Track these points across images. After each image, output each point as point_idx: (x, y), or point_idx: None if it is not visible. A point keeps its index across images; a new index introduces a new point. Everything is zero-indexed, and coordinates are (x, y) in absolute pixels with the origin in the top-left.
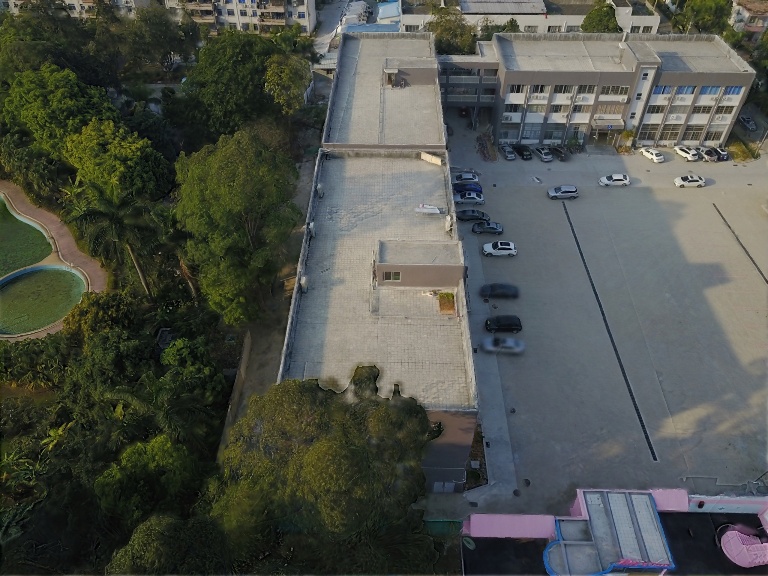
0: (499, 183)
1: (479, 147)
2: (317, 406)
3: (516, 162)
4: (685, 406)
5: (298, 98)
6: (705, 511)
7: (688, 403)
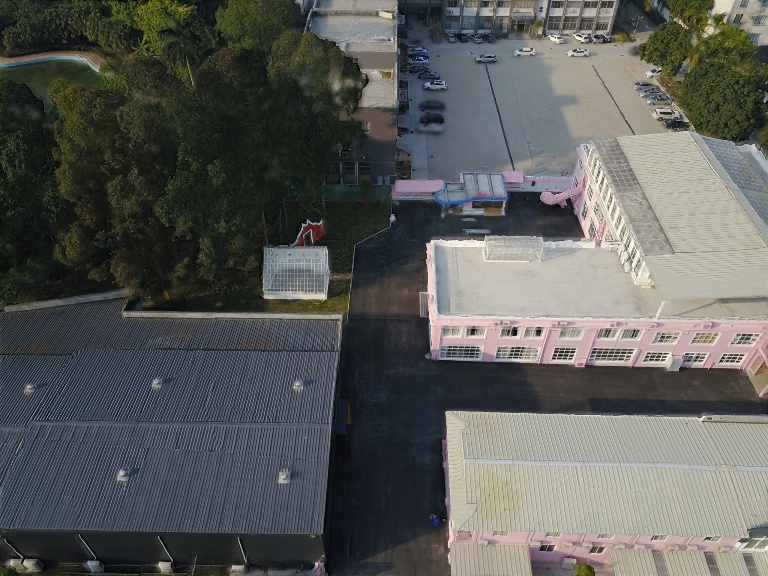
0: (442, 55)
1: (430, 35)
2: None
3: (456, 44)
4: (541, 156)
5: None
6: (537, 191)
7: (543, 154)
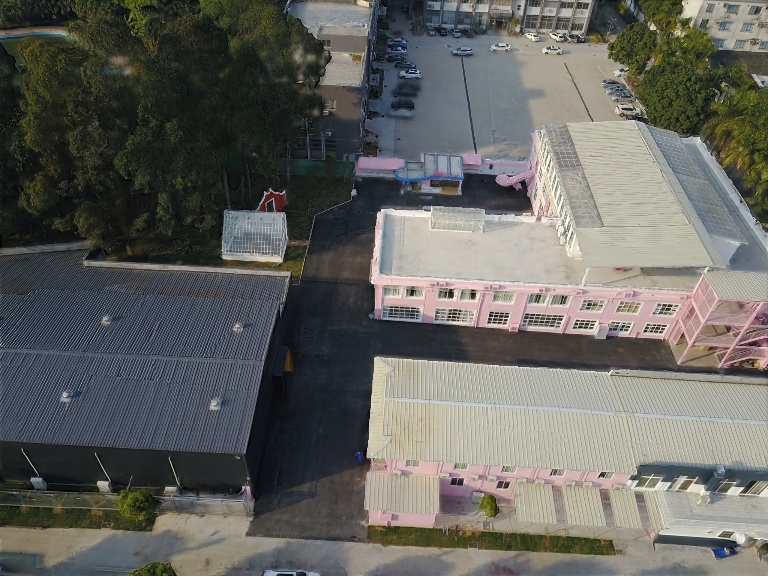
0: (420, 46)
1: (411, 28)
2: None
3: (436, 37)
4: (504, 143)
5: None
6: (495, 174)
7: (506, 142)
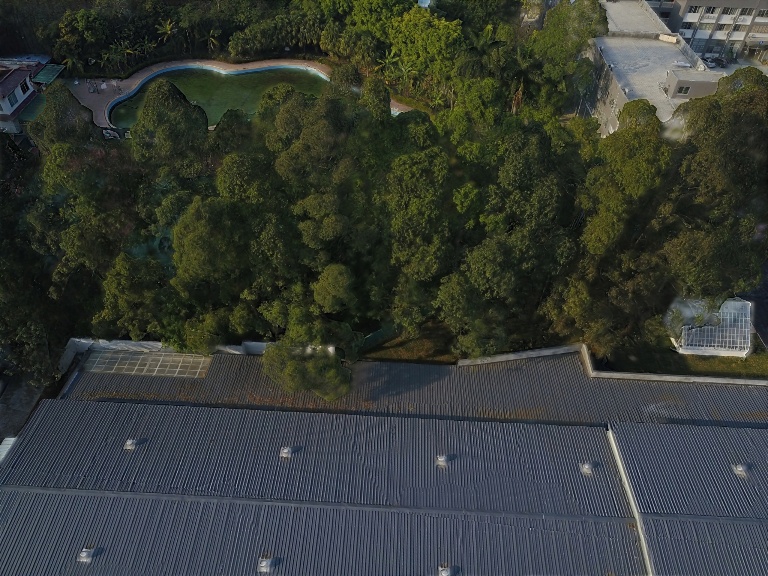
0: None
1: None
2: None
3: None
4: None
5: (540, 5)
6: None
7: None
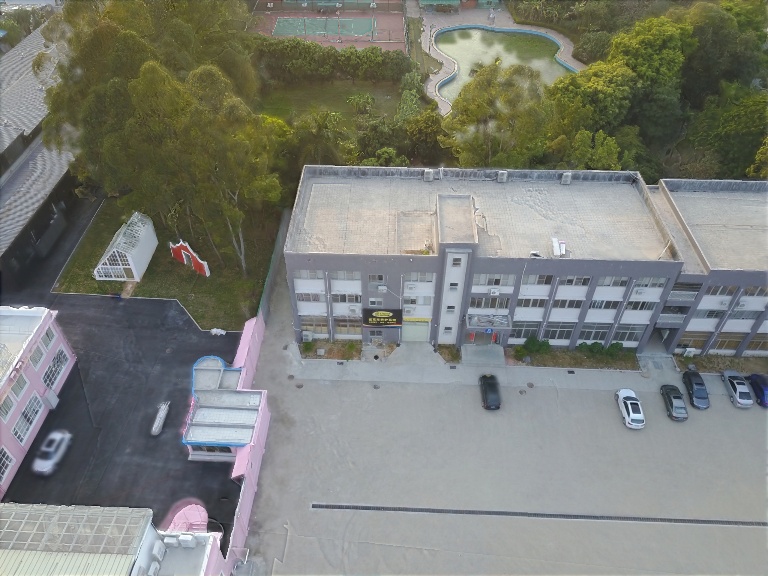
0: None
1: None
2: (202, 83)
3: None
4: (382, 565)
5: None
6: None
7: (386, 571)
